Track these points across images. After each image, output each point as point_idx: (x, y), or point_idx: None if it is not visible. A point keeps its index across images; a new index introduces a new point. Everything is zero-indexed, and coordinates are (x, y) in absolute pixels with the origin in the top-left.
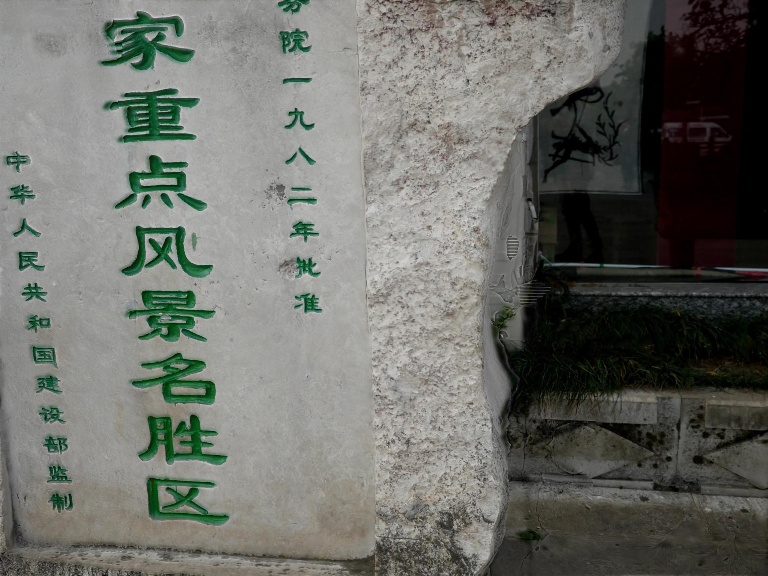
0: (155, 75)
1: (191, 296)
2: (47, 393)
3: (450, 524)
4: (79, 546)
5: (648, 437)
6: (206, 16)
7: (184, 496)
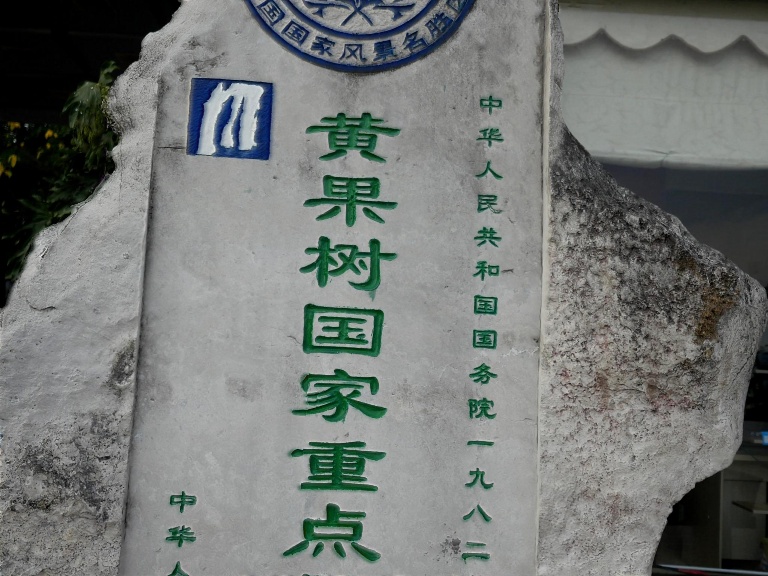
0: (343, 427)
1: None
2: None
3: None
4: None
5: None
6: (401, 379)
7: None
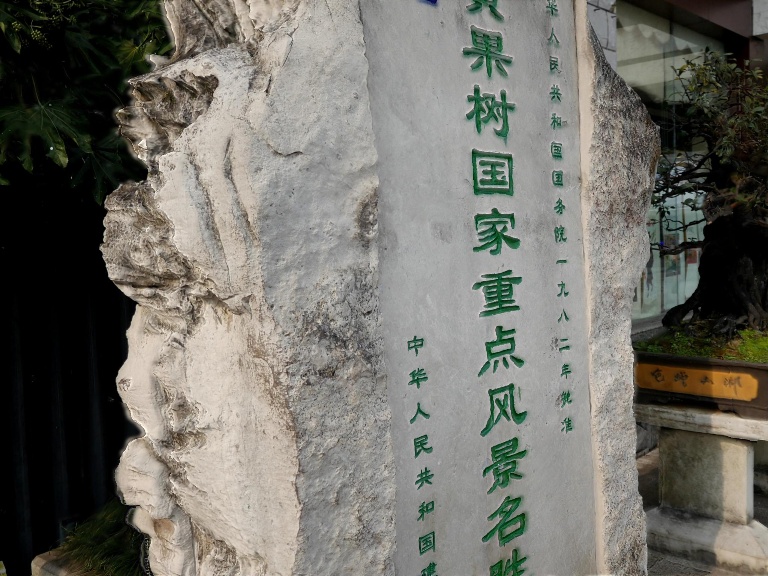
0: None
1: (515, 442)
2: None
3: (634, 556)
4: None
5: None
6: (525, 214)
7: None
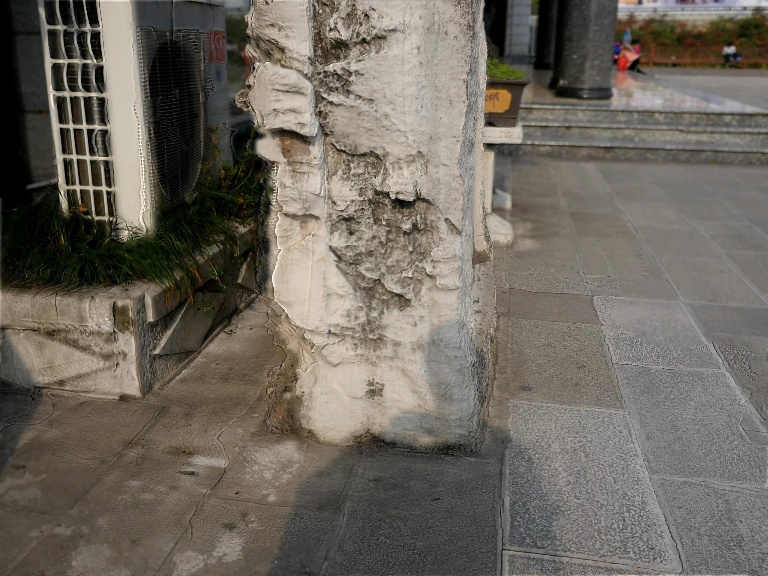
0: None
1: None
2: None
3: None
4: None
5: None
6: None
7: None
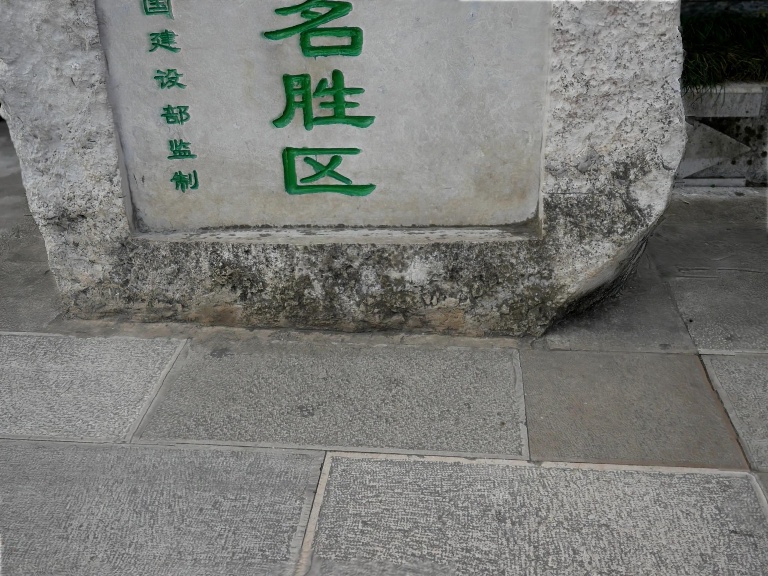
0: None
1: None
2: (162, 51)
3: (627, 174)
4: (208, 228)
5: (746, 132)
6: None
7: (325, 165)
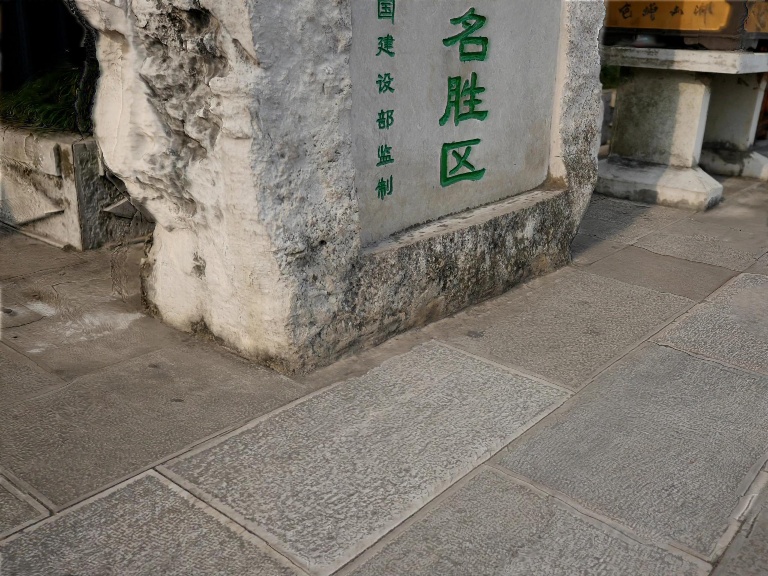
0: None
1: None
2: (383, 56)
3: (587, 138)
4: (395, 233)
5: None
6: None
7: (462, 157)
